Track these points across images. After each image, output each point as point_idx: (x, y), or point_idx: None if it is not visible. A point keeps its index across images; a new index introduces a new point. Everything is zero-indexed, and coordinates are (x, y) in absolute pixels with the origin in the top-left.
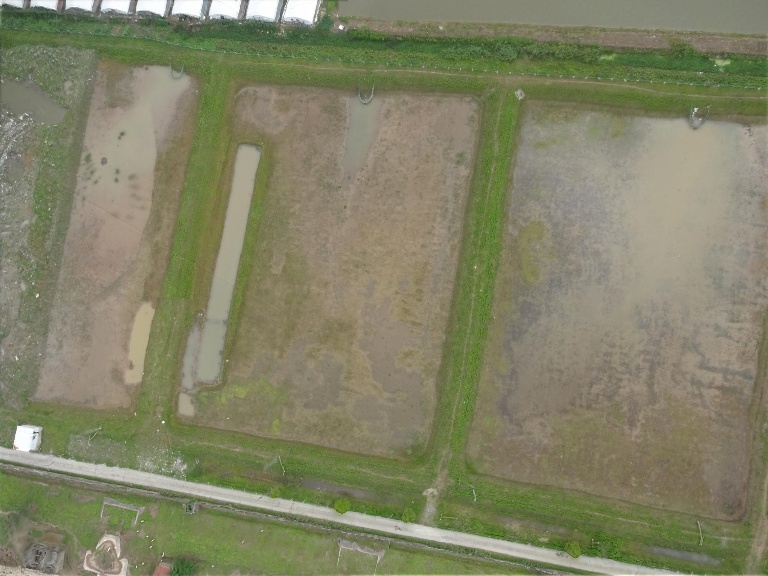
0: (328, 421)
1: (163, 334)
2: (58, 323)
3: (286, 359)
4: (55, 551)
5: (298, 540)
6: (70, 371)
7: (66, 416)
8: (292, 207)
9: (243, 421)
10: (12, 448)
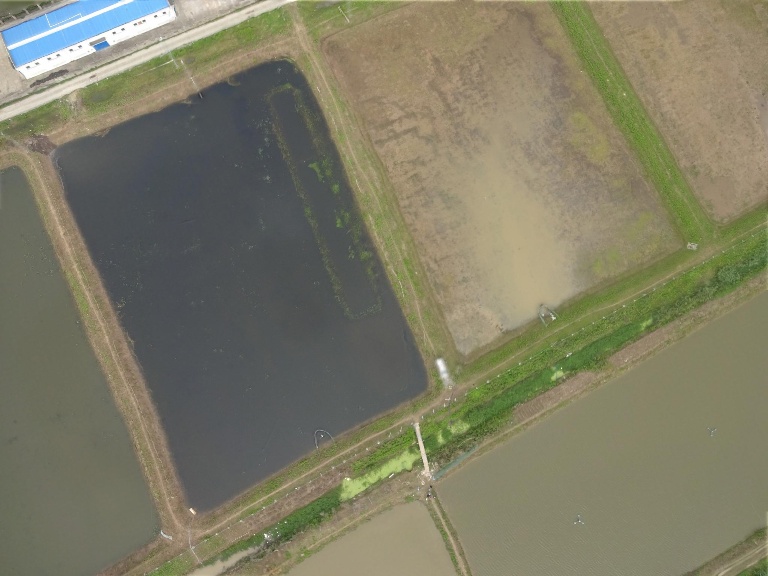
0: None
1: None
2: None
3: None
4: None
5: None
6: None
7: None
8: None
9: None
10: None
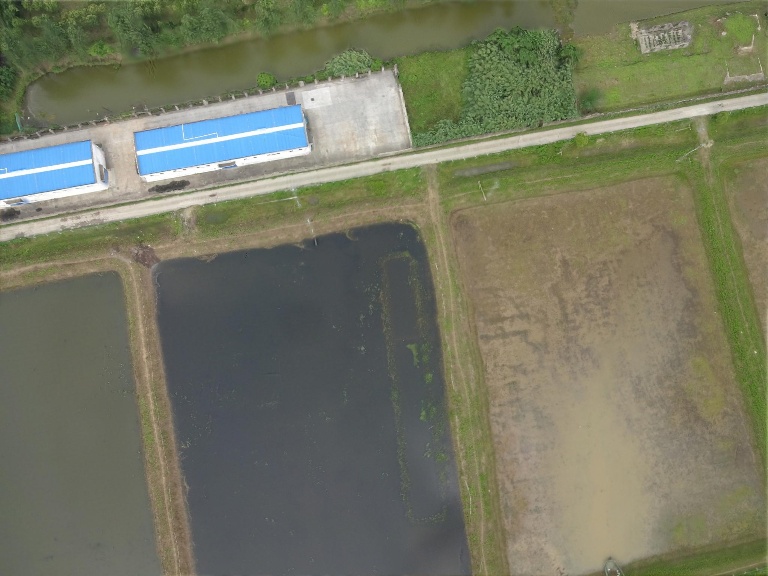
0: None
1: None
2: None
3: None
4: None
5: None
6: None
7: None
8: None
9: None
10: None
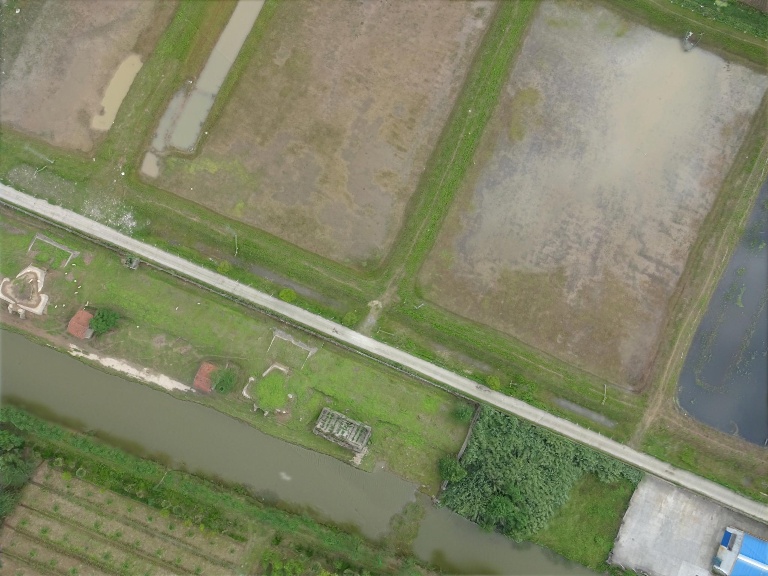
0: (293, 217)
1: (146, 88)
2: (32, 47)
3: (266, 148)
4: None
5: (233, 321)
6: (33, 99)
7: (16, 141)
8: (311, 7)
9: (207, 196)
10: None
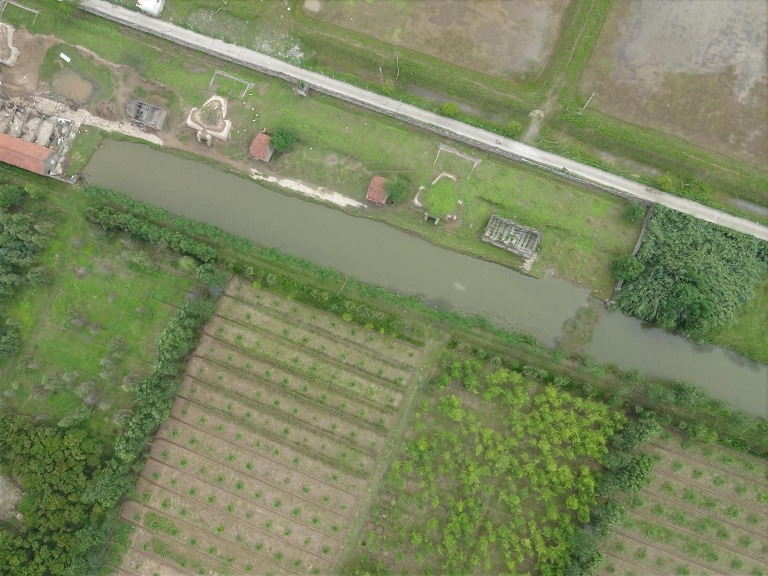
0: (449, 37)
1: None
2: None
3: None
4: (159, 107)
5: (399, 138)
6: None
7: None
8: None
9: (366, 24)
10: (133, 10)
